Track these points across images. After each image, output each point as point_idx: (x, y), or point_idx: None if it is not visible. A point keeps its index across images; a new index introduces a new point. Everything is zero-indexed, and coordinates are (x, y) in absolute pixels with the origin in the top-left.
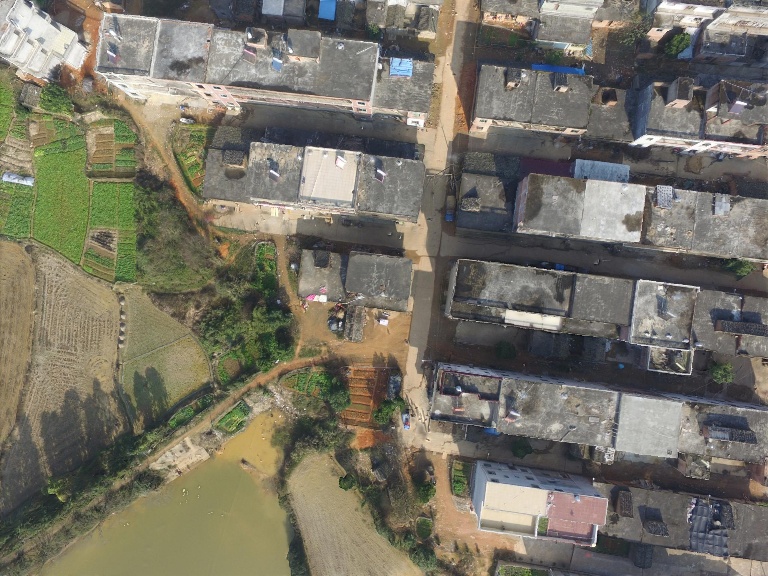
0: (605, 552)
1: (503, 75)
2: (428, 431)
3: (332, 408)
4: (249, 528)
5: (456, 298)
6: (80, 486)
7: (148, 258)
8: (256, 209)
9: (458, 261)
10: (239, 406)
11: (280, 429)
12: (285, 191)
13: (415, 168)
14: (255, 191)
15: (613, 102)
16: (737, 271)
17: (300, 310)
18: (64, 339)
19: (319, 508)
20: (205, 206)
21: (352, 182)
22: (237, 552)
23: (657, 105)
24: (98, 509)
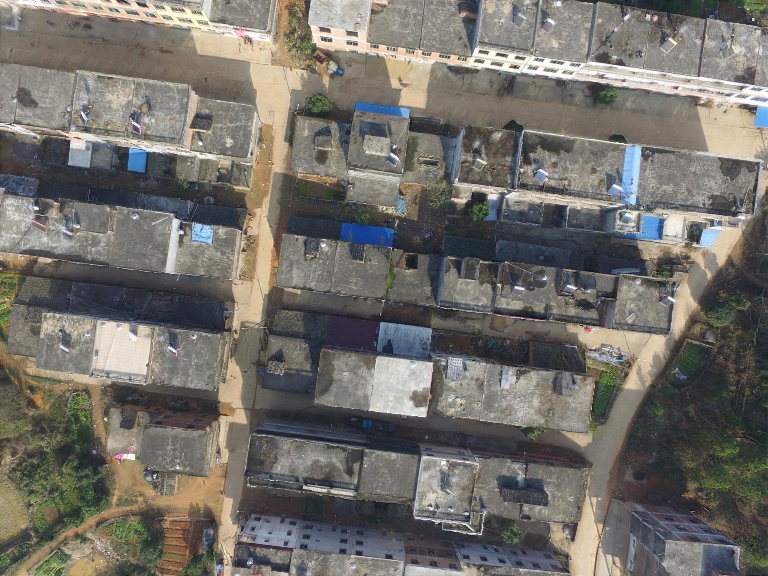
0: None
1: (303, 244)
2: None
3: None
4: None
5: (248, 472)
6: None
7: None
8: None
9: (249, 437)
10: (56, 555)
11: (101, 573)
12: (78, 363)
13: (210, 342)
14: (47, 363)
15: (414, 269)
16: (527, 435)
17: (116, 461)
18: None
19: None
20: None
21: (146, 355)
22: None
23: (451, 277)
24: None
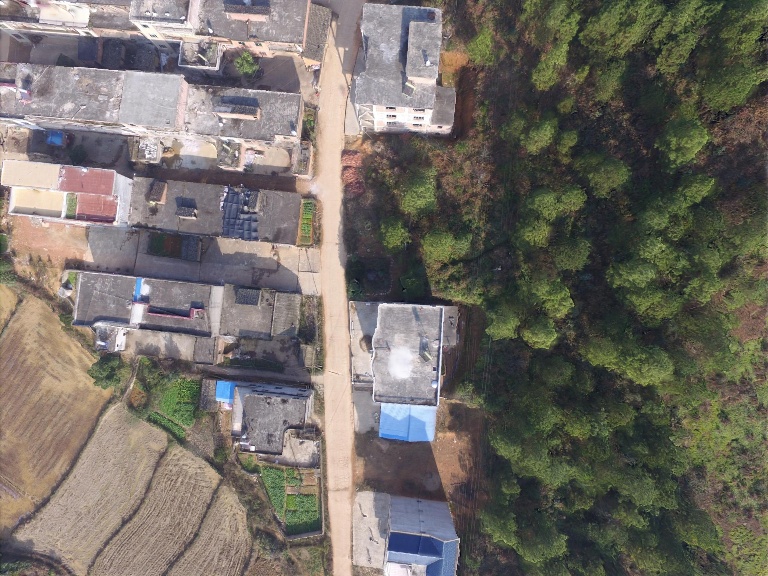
0: (165, 255)
1: None
2: (5, 152)
3: None
4: None
5: None
6: None
7: None
8: None
9: None
10: None
11: None
12: None
13: None
14: None
15: None
16: None
17: None
18: None
19: None
20: None
21: None
22: None
23: None
24: None
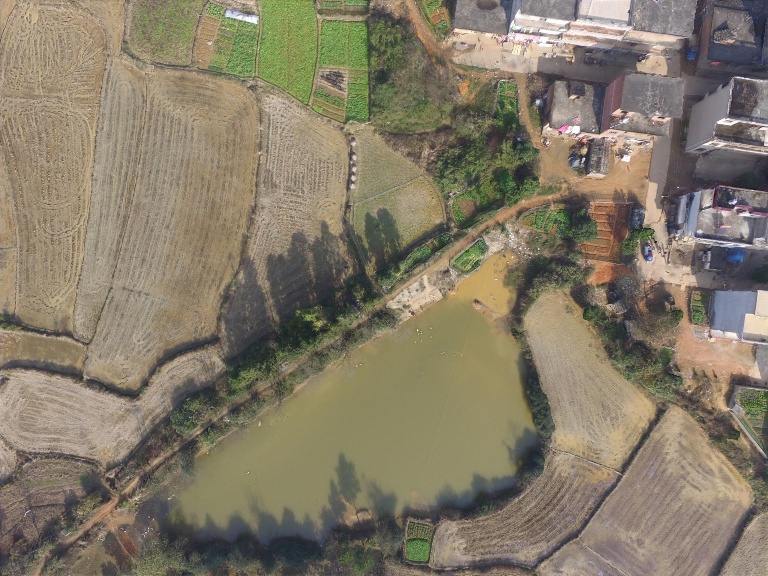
0: None
1: None
2: (668, 263)
3: (571, 244)
4: (482, 367)
5: (730, 115)
6: (333, 315)
7: (394, 91)
8: (497, 47)
9: (733, 79)
10: (477, 244)
11: (513, 269)
12: (562, 9)
13: None
14: (532, 8)
15: None
16: None
17: (541, 148)
18: (290, 181)
19: (554, 344)
20: (445, 43)
21: (628, 2)
22: (469, 391)
23: None
24: (335, 347)
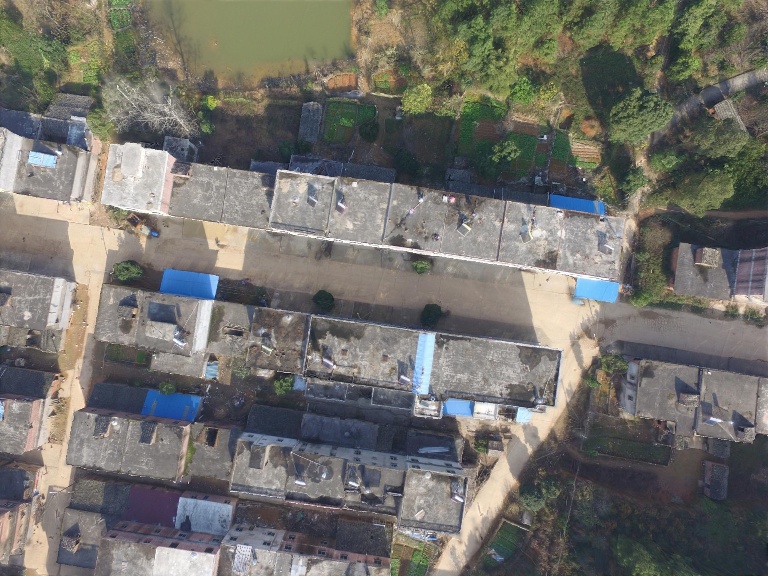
0: None
1: (95, 422)
2: None
3: None
4: None
5: None
6: None
7: None
8: None
9: None
10: None
11: None
12: None
13: None
14: None
15: (211, 446)
16: None
17: None
18: None
19: None
20: None
21: None
22: None
23: (244, 460)
24: None
